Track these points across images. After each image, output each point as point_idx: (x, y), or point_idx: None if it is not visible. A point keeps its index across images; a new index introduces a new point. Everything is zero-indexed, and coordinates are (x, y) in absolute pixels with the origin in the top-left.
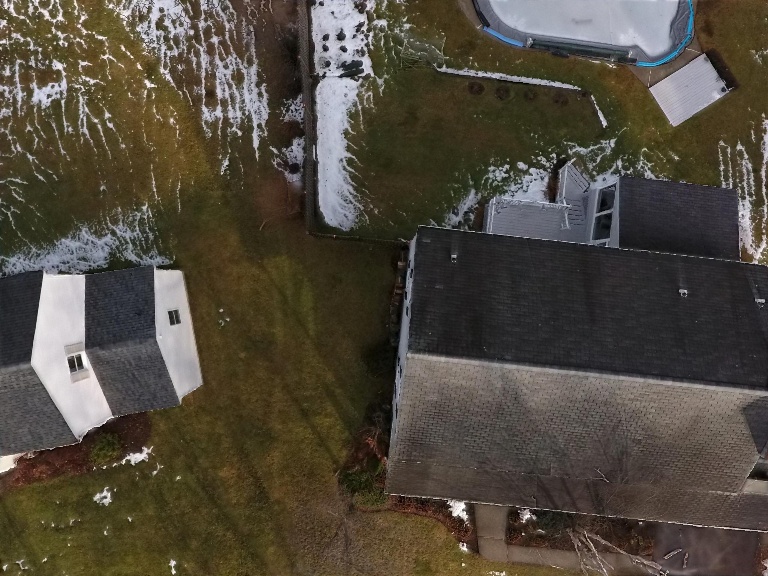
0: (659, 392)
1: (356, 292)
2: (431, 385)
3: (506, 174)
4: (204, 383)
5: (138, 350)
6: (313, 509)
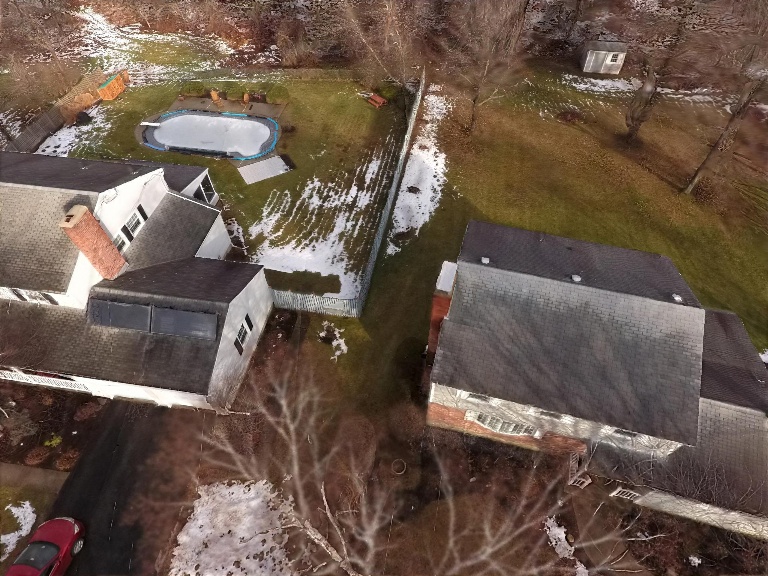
0: (5, 193)
1: None
2: None
3: None
4: None
5: None
6: None
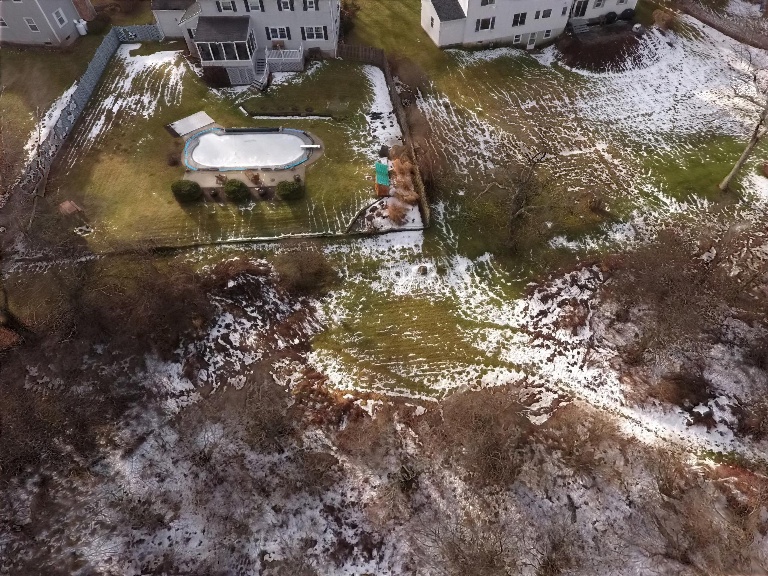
0: None
1: None
2: None
3: (293, 81)
4: None
5: None
6: (369, 2)
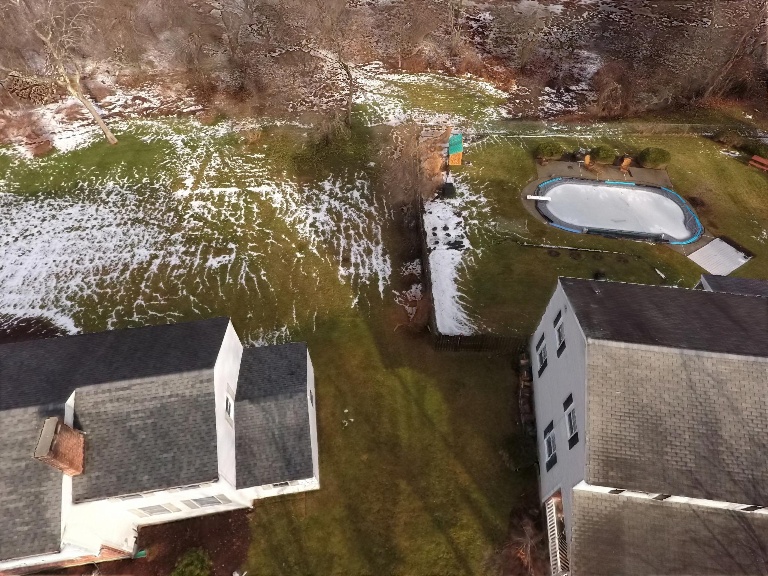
0: None
1: (480, 394)
2: (615, 376)
3: None
4: (320, 488)
5: (286, 405)
6: None
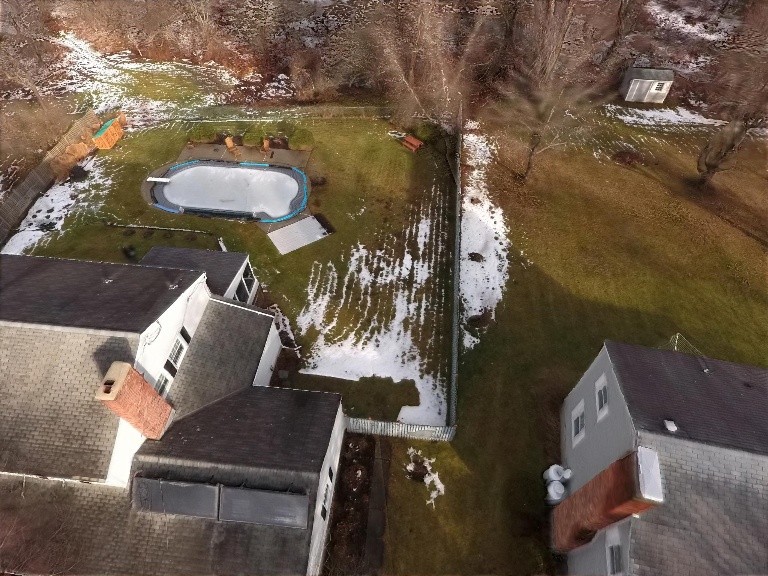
0: (12, 337)
1: None
2: None
3: None
4: None
5: None
6: None
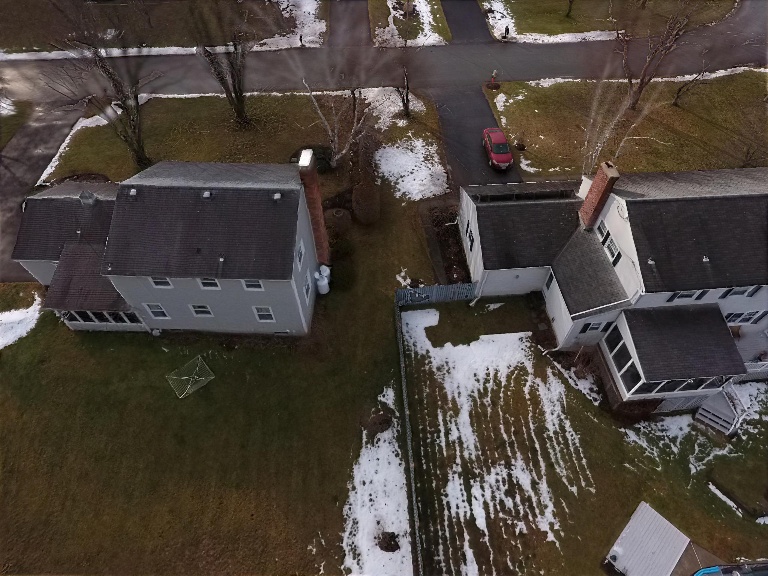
0: None
1: None
2: None
3: None
4: None
5: None
6: None
